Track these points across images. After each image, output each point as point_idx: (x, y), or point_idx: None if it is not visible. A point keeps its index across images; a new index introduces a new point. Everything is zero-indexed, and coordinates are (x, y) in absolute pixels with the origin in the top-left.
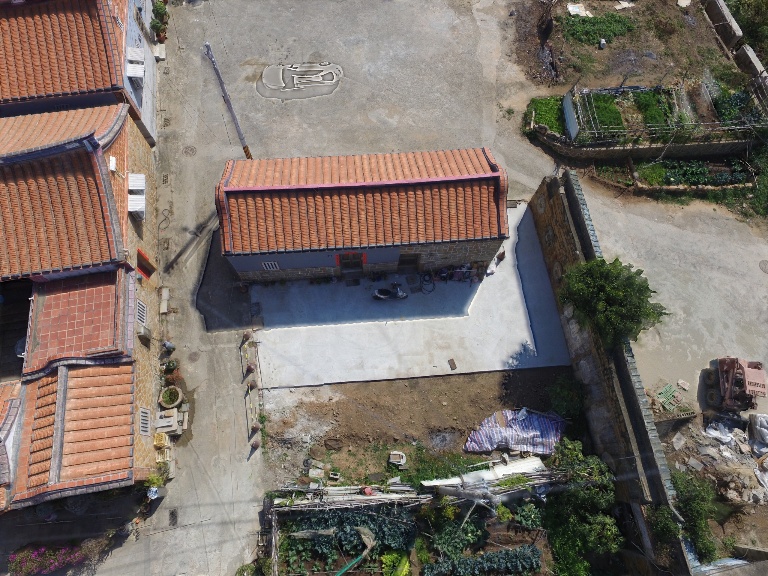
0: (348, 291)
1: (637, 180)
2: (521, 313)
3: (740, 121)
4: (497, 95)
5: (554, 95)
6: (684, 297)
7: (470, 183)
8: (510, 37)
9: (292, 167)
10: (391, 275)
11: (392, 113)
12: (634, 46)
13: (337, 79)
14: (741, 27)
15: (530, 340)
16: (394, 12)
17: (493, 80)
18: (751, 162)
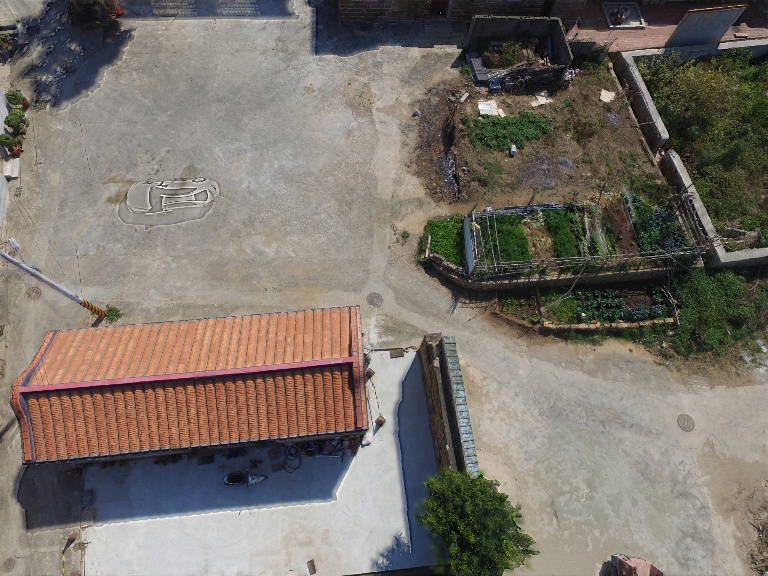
0: (199, 471)
1: (544, 317)
2: (398, 495)
3: (660, 246)
4: (391, 215)
5: (455, 214)
6: (589, 466)
7: (320, 369)
8: (411, 143)
9: (119, 342)
10: (251, 448)
11: (270, 241)
12: (549, 152)
13: (211, 199)
14: (670, 124)
15: (405, 531)
16: (284, 114)
17: (388, 196)
18: (673, 292)
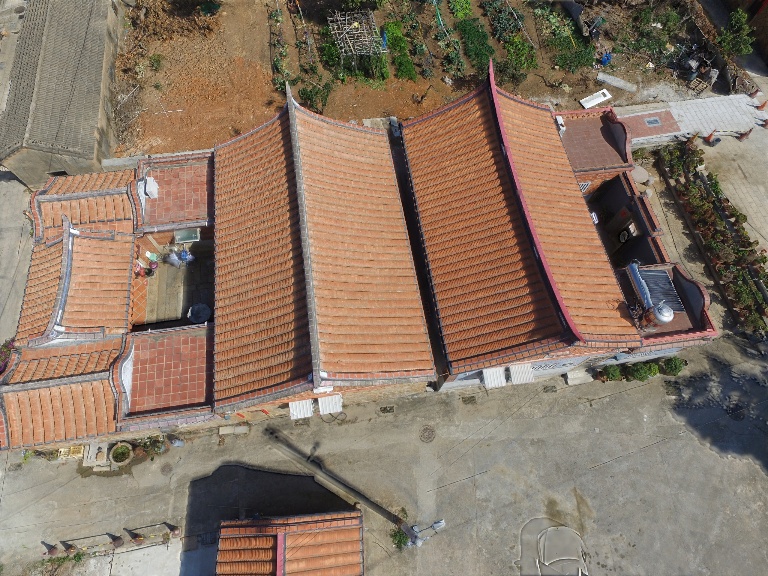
0: None
1: None
2: None
3: None
4: None
5: None
6: None
7: None
8: None
9: None
10: None
11: None
12: None
13: None
14: None
15: None
16: None
17: None
18: None
